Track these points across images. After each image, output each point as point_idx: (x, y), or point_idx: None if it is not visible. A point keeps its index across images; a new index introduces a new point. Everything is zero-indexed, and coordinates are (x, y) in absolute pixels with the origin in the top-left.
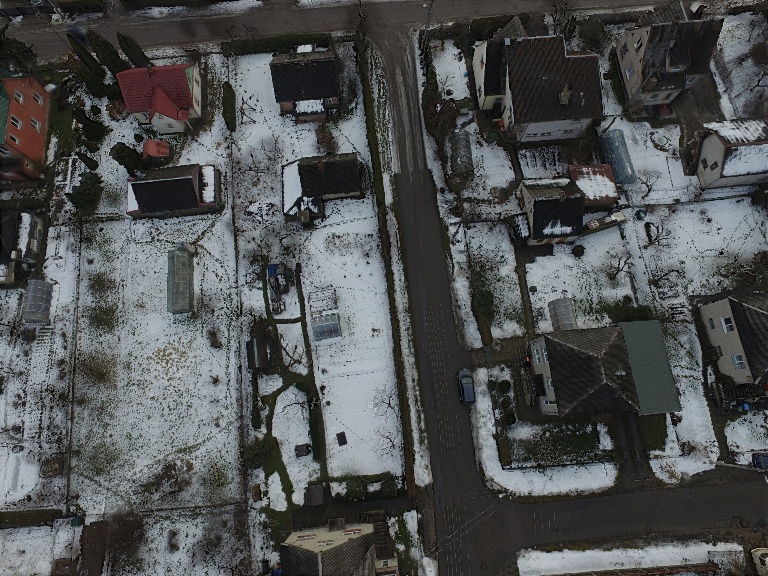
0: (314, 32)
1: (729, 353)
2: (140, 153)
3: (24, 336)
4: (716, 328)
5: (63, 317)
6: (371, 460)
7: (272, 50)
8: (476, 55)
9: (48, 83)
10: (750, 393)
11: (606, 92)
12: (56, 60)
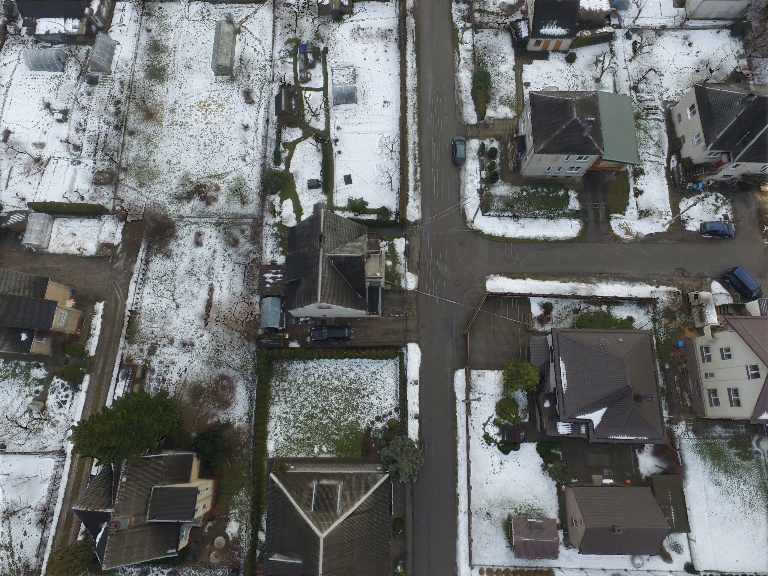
0: None
1: (690, 136)
2: None
3: (89, 78)
4: (682, 120)
5: (122, 69)
6: (371, 197)
7: None
8: None
9: None
10: (704, 170)
11: None
12: None
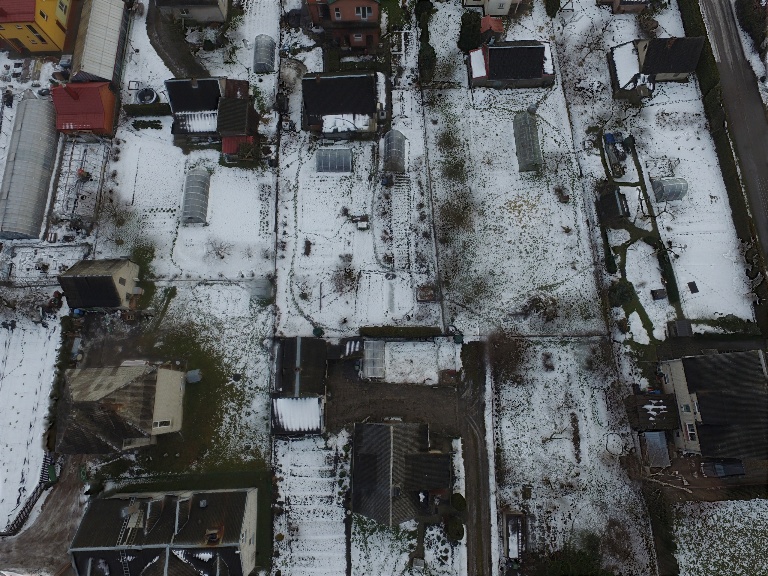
0: None
1: None
2: None
3: (387, 180)
4: None
5: (416, 168)
6: (723, 307)
7: None
8: None
9: None
10: None
11: None
12: None
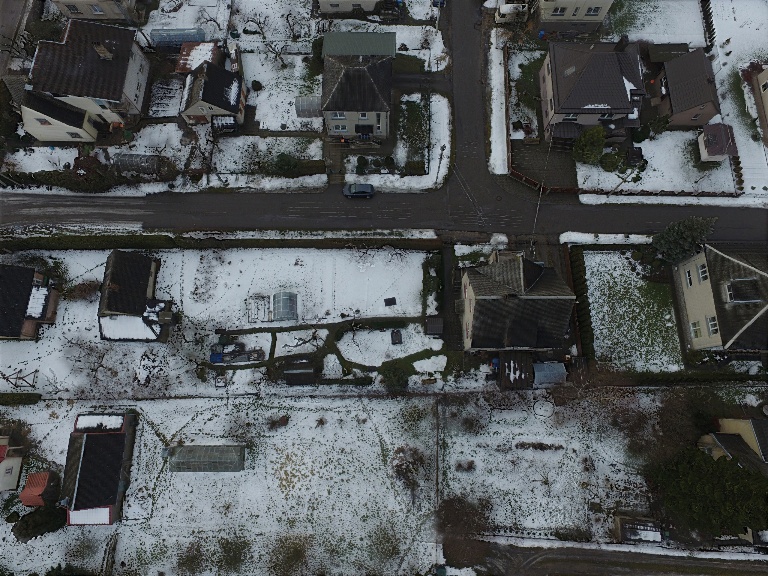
0: None
1: None
2: None
3: None
4: (338, 3)
5: None
6: (411, 278)
7: None
8: (33, 130)
9: None
10: None
11: None
12: None
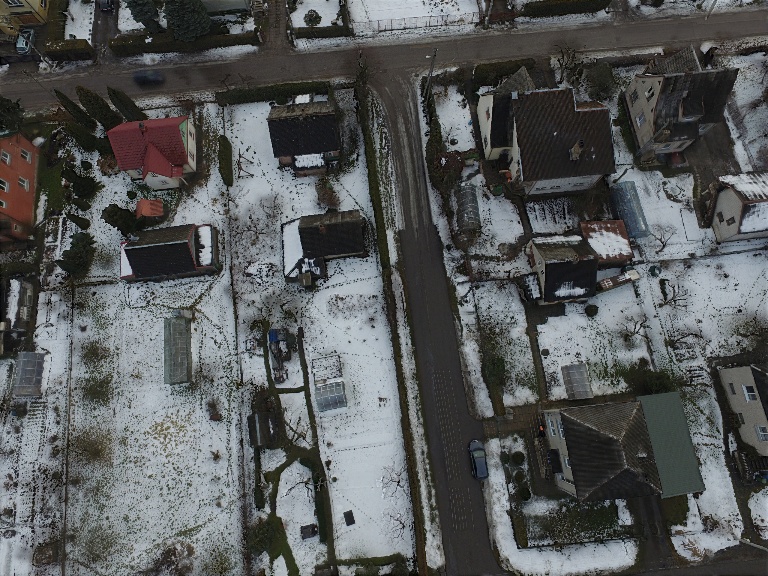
0: (312, 79)
1: (752, 423)
2: (133, 211)
3: (15, 412)
4: (737, 394)
5: (55, 390)
6: (380, 541)
7: (269, 98)
8: (481, 104)
9: (36, 136)
10: None
11: (616, 139)
12: (44, 111)
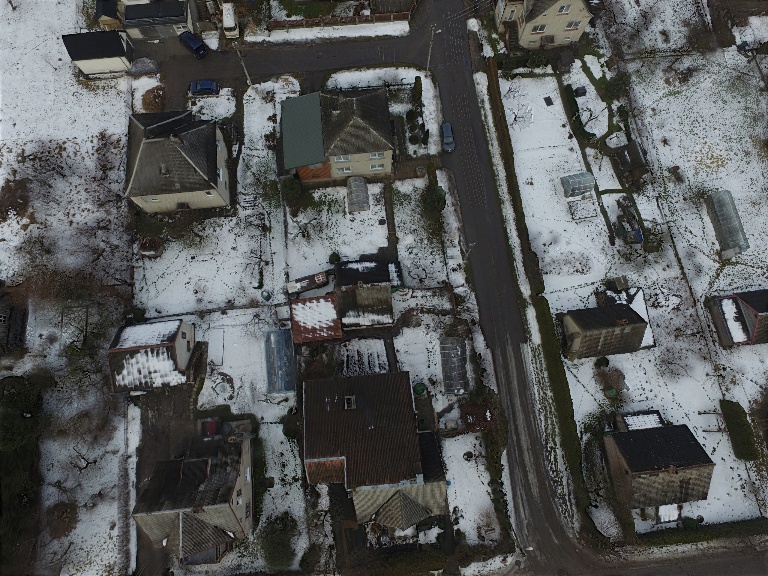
0: (657, 559)
1: (222, 155)
2: None
3: None
4: None
5: None
6: None
7: None
8: None
9: None
10: None
11: (274, 458)
12: None
